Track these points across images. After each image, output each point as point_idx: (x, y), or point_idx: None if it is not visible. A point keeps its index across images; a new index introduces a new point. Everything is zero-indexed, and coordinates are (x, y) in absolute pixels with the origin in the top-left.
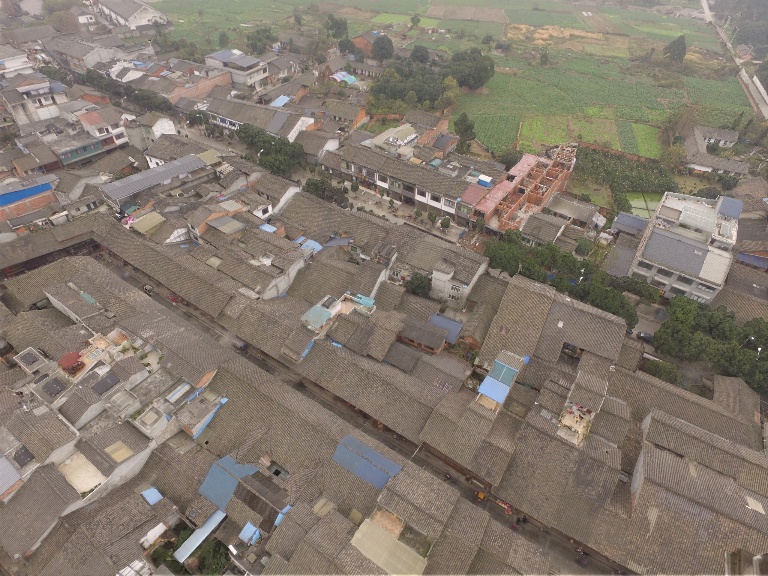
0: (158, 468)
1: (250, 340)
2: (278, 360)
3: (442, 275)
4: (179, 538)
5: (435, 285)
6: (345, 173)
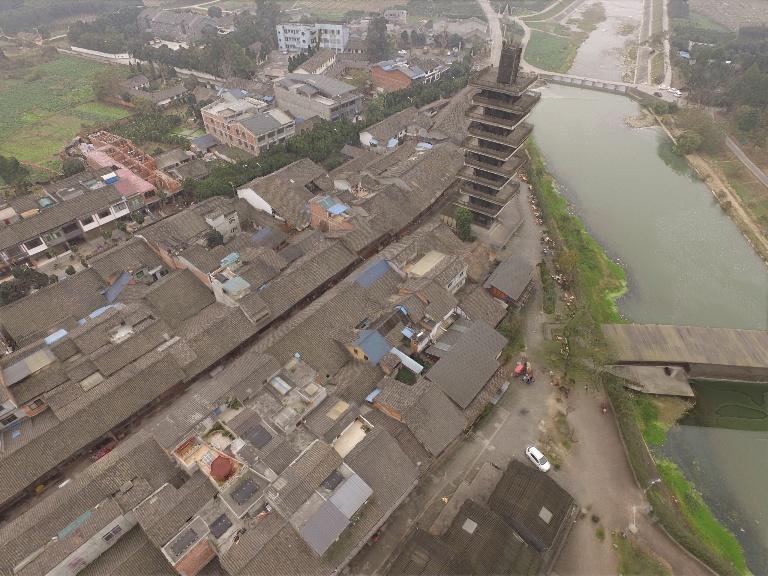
0: (348, 399)
1: (228, 349)
2: (260, 329)
3: (220, 219)
4: (404, 380)
5: (220, 232)
6: None
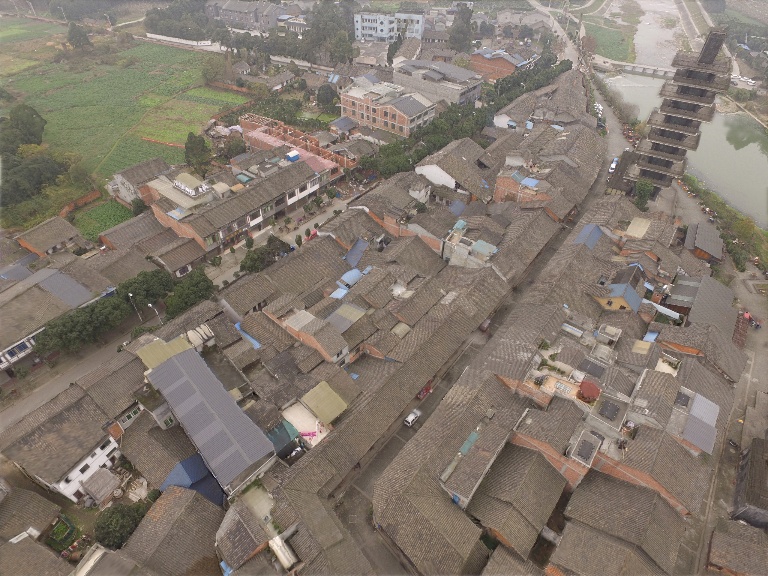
0: None
1: (495, 303)
2: None
3: None
4: None
5: None
6: (213, 249)
